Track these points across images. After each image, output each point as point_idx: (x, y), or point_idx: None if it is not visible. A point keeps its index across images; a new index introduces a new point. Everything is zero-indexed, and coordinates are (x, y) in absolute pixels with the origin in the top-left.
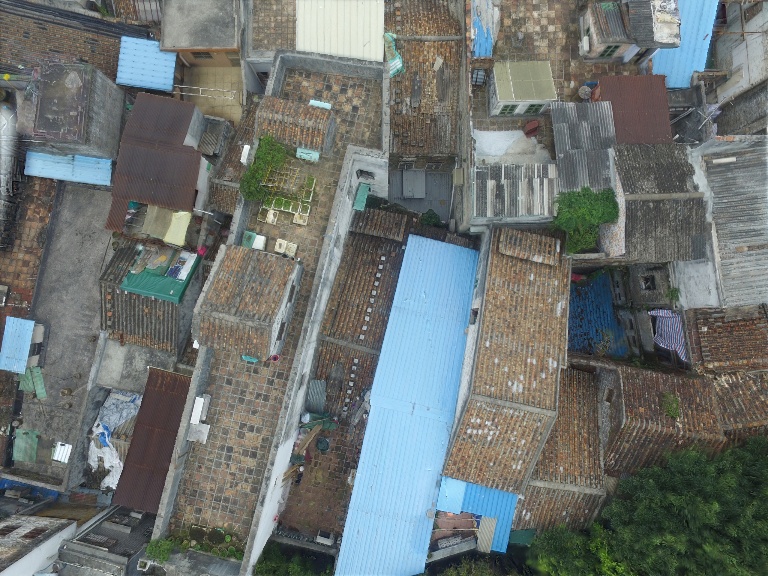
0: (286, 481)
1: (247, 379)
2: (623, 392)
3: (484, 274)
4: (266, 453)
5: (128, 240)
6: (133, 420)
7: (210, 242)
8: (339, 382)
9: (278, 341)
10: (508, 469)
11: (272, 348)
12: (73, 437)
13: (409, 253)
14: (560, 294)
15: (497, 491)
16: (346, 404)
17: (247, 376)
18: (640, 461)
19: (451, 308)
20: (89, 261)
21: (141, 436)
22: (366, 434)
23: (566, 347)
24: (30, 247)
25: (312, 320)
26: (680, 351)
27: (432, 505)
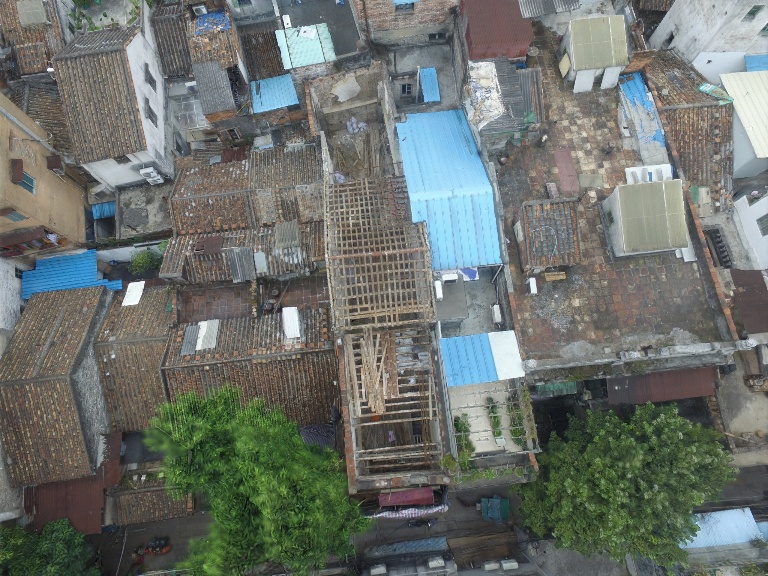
0: None
1: None
2: None
3: None
4: None
5: None
6: None
7: None
8: None
9: None
10: None
11: None
12: None
13: None
14: None
15: None
16: None
17: None
18: None
19: None
20: None
21: None
22: None
23: None
24: None
25: None
26: None
27: None
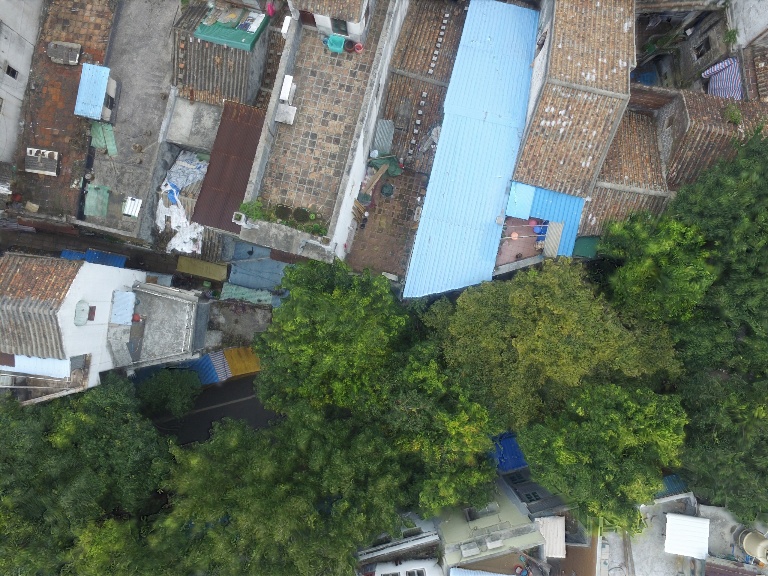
0: (355, 213)
1: (331, 71)
2: (686, 105)
3: (551, 4)
4: (349, 140)
5: (198, 1)
6: (199, 183)
7: (277, 7)
8: (407, 118)
9: (364, 22)
10: (577, 168)
11: (362, 14)
12: (143, 192)
13: (473, 8)
14: (626, 17)
15: (564, 196)
16: (411, 147)
17: (330, 68)
18: (701, 172)
19: (516, 49)
20: (158, 27)
21: (217, 162)
22: (439, 142)
23: (634, 53)
24: (101, 11)
25: (393, 18)
26: (735, 97)
27: (501, 212)
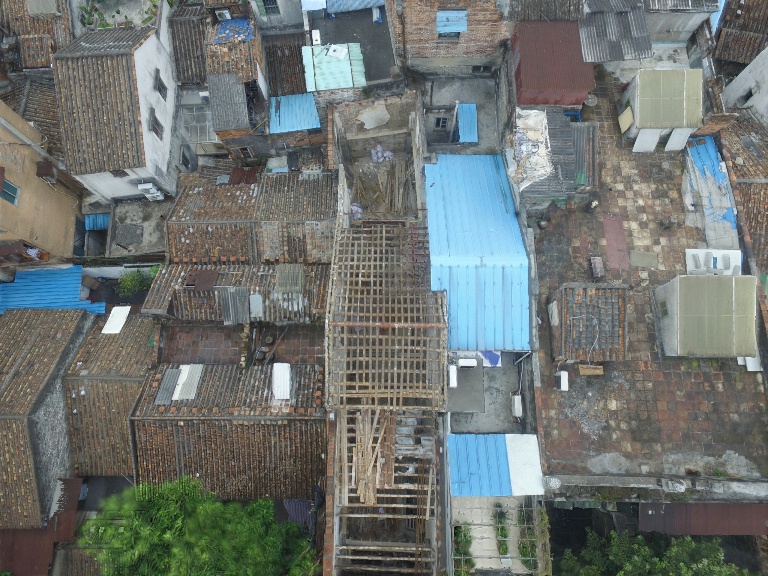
0: None
1: None
2: None
3: None
4: None
5: None
6: None
7: None
8: None
9: None
10: None
11: None
12: None
13: None
14: None
15: None
16: None
17: None
18: None
19: None
20: None
21: None
22: None
23: None
24: None
25: None
26: None
27: None
